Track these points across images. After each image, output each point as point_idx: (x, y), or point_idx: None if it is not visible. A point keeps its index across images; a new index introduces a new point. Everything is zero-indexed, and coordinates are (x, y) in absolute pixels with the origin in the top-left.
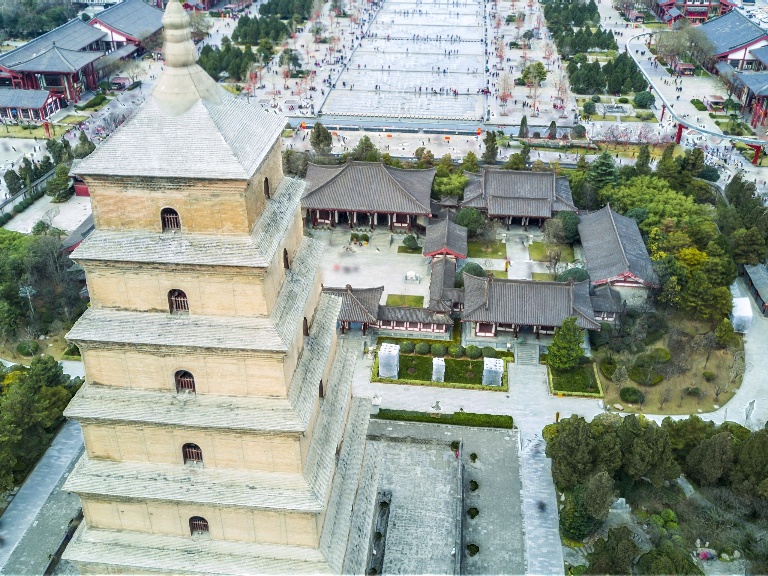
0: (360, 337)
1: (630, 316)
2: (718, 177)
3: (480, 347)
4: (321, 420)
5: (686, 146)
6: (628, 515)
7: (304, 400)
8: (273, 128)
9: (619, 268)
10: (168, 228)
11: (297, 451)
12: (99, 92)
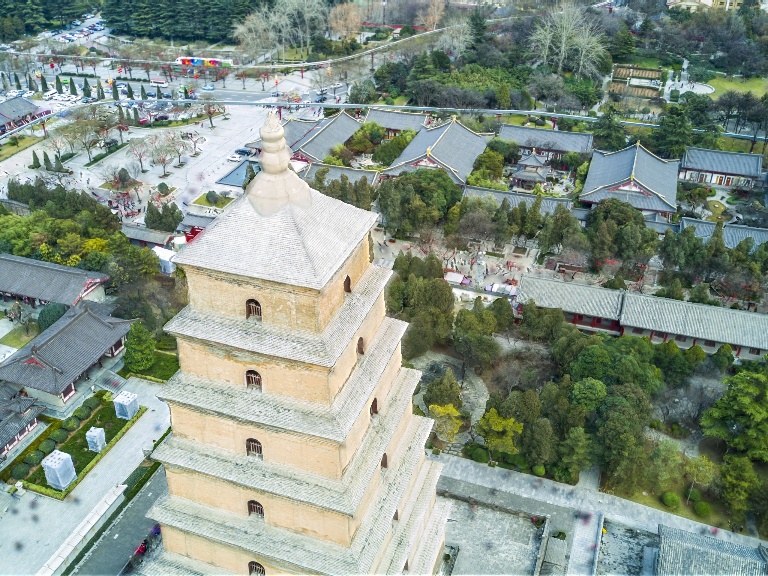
0: None
1: None
2: None
3: (76, 408)
4: None
5: None
6: None
7: None
8: None
9: (77, 282)
10: None
11: None
12: None
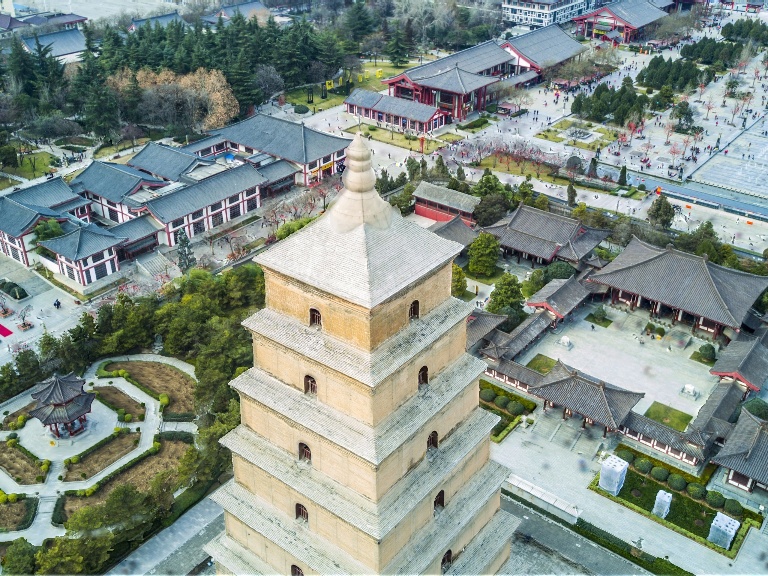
0: (599, 437)
1: None
2: None
3: (727, 496)
4: (429, 528)
5: None
6: None
7: (395, 510)
8: (436, 257)
9: None
10: (316, 324)
11: (376, 552)
12: (484, 114)
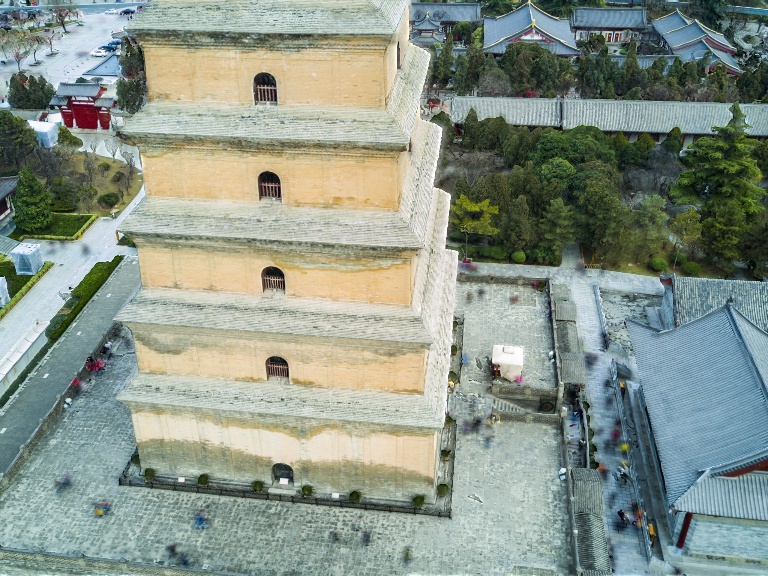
0: None
1: None
2: None
3: None
4: None
5: None
6: None
7: None
8: None
9: None
10: None
11: None
12: None
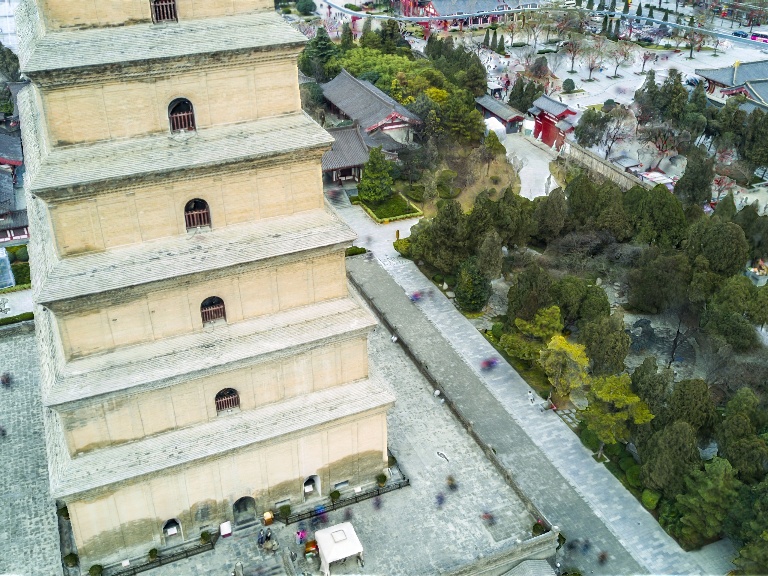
0: None
1: (406, 154)
2: (410, 47)
3: None
4: None
5: (381, 19)
6: (503, 283)
7: None
8: None
9: (385, 112)
10: None
11: (319, 178)
12: None
